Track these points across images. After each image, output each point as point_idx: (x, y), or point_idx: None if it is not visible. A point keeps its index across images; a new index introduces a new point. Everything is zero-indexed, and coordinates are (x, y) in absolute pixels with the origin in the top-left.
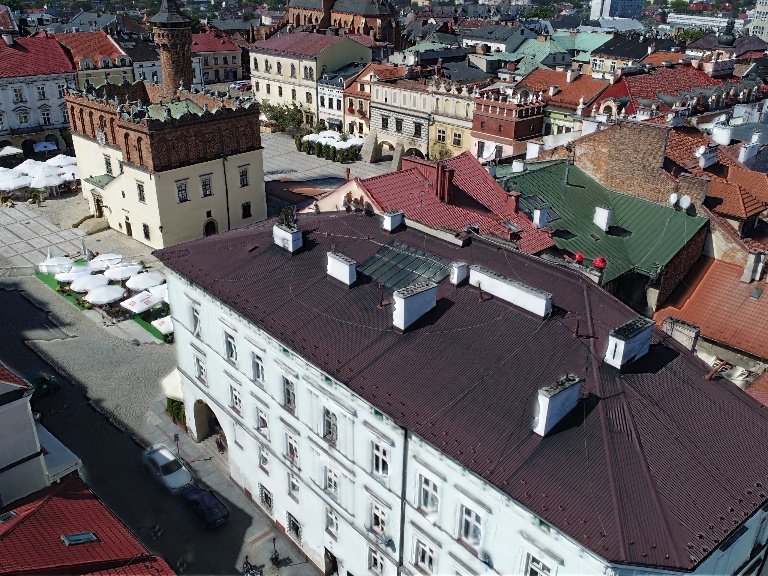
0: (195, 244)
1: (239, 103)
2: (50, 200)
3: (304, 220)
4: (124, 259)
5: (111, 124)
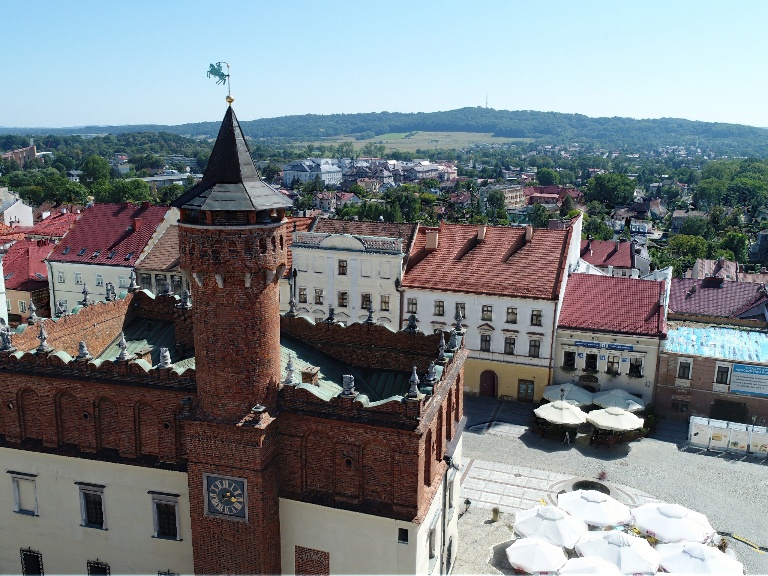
0: None
1: (3, 325)
2: (514, 539)
3: None
4: (7, 229)
5: None
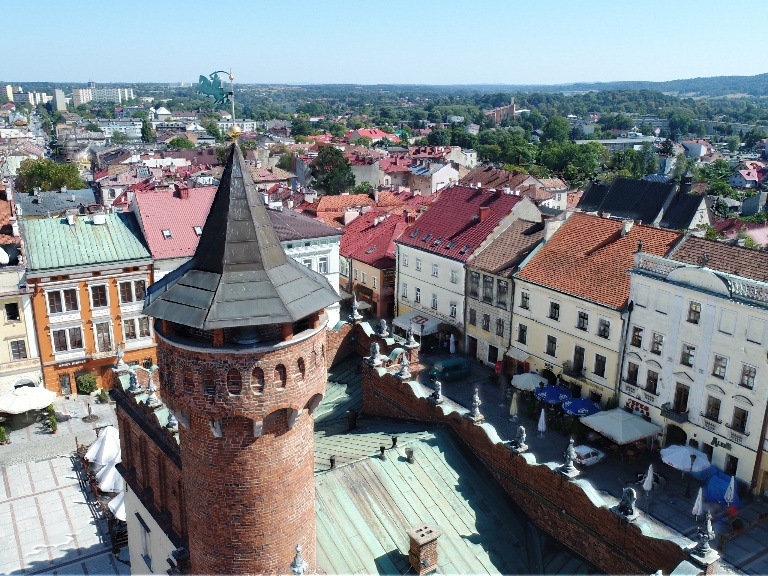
0: (321, 225)
1: None
2: None
3: None
4: None
5: None
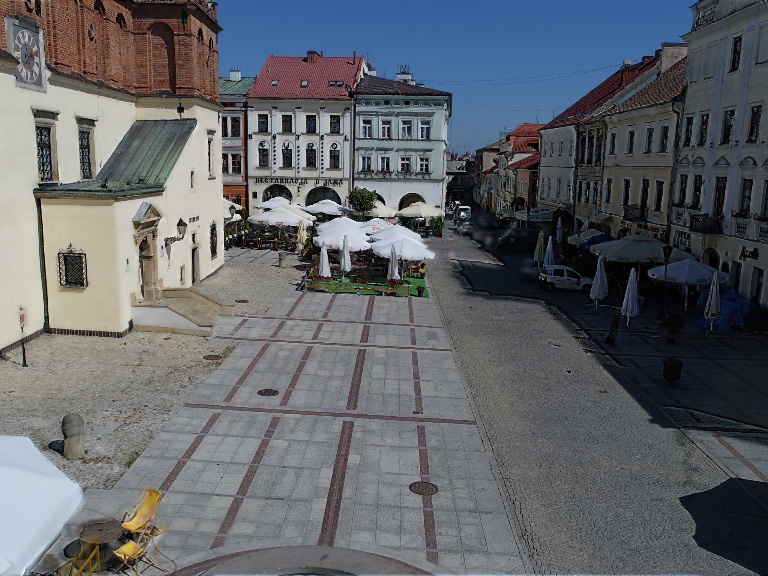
0: None
1: None
2: None
3: (378, 81)
4: (484, 81)
5: (66, 4)
